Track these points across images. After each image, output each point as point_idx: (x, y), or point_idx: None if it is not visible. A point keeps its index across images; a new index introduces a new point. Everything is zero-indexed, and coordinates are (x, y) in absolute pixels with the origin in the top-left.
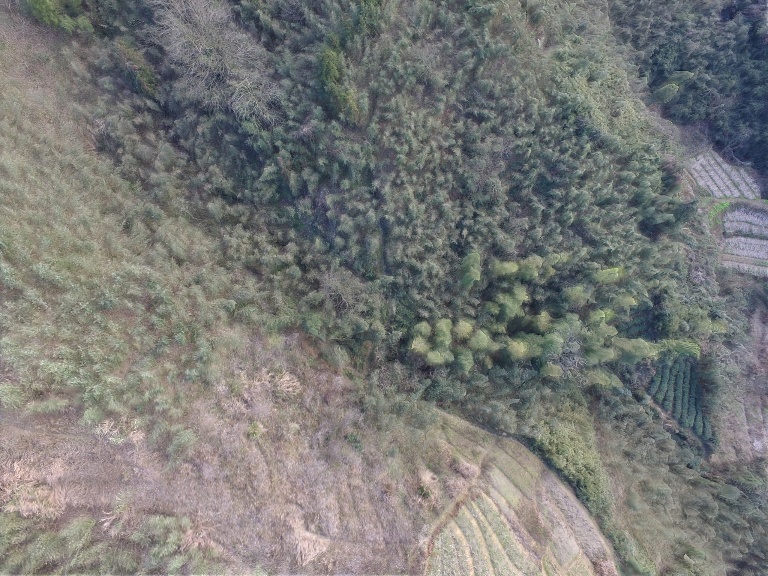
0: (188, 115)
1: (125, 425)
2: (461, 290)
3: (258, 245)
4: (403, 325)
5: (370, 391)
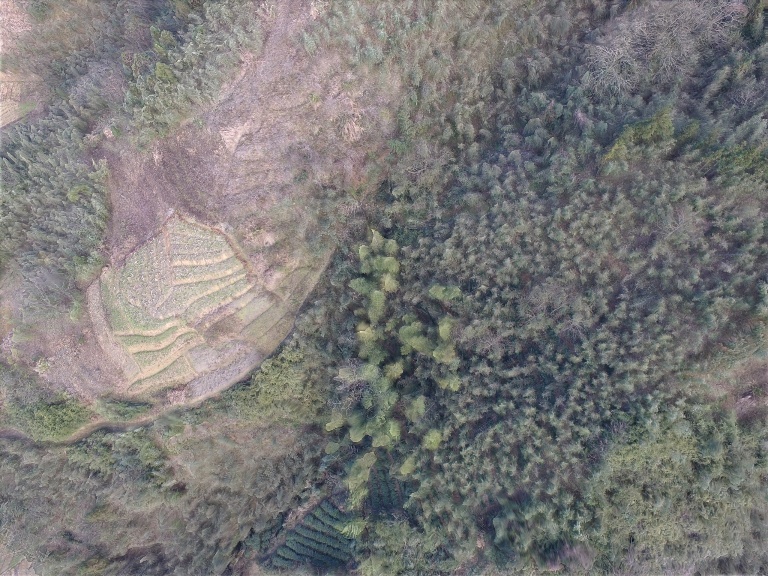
0: (604, 37)
1: (323, 6)
2: (429, 288)
3: (474, 104)
4: (400, 235)
5: (340, 195)
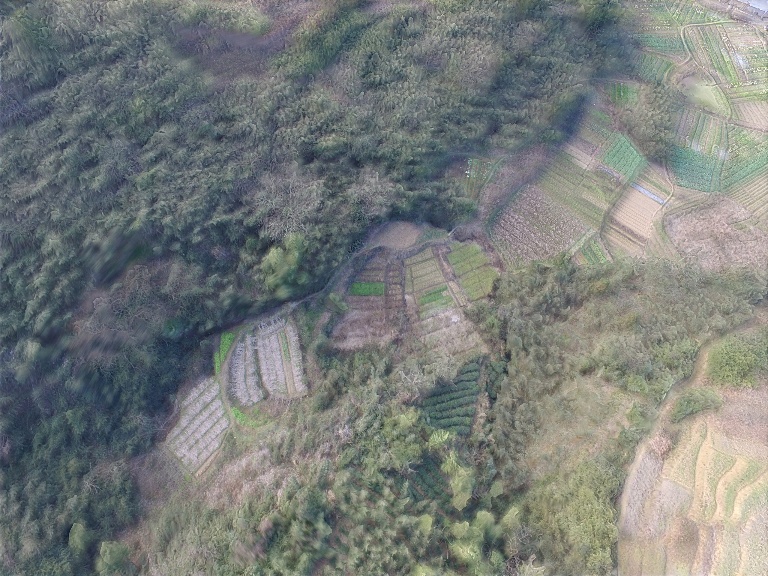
0: None
1: None
2: None
3: None
4: None
5: None
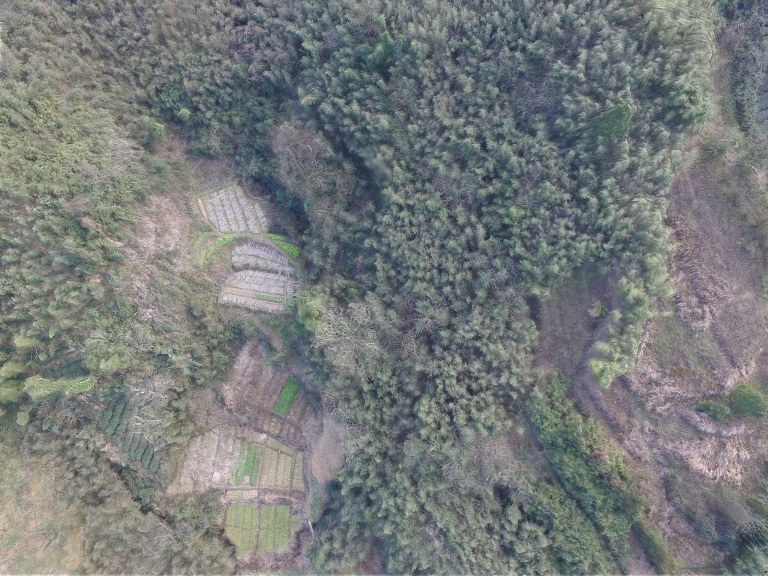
0: None
1: None
2: None
3: None
4: None
5: None
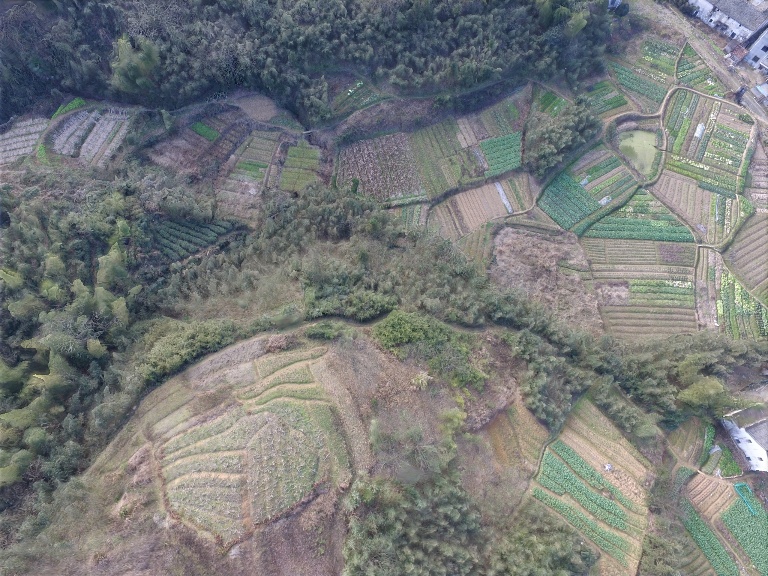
0: None
1: None
2: None
3: None
4: None
5: (3, 561)
